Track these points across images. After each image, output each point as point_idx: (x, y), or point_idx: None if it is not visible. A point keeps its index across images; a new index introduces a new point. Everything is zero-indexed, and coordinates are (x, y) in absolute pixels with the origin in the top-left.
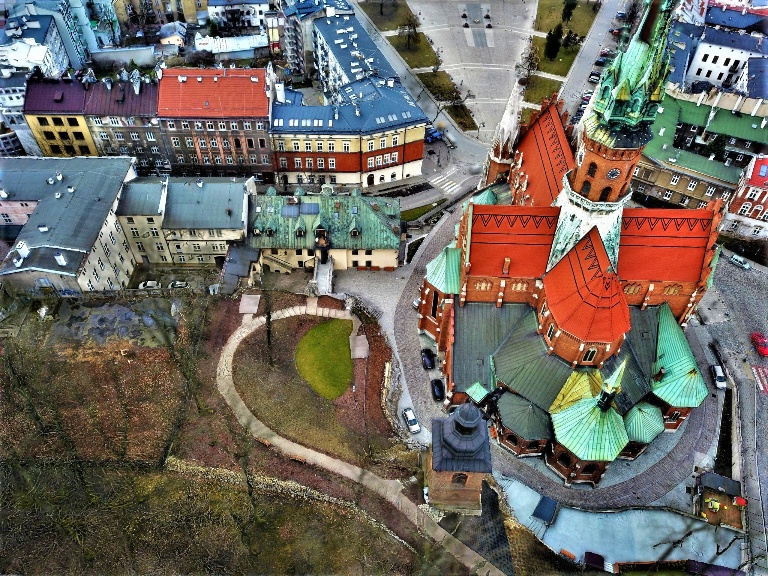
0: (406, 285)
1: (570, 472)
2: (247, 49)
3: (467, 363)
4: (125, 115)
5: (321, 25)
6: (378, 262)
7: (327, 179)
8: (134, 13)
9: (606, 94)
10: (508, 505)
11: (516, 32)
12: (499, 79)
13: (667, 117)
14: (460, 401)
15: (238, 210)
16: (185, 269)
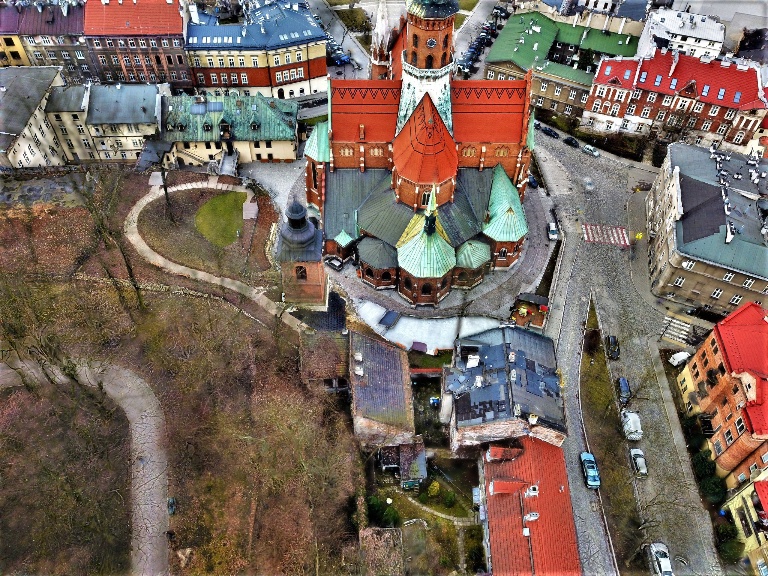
0: (302, 173)
1: (413, 294)
2: None
3: (336, 217)
4: (55, 34)
5: None
6: (278, 155)
7: (242, 94)
8: None
9: None
10: (358, 315)
11: None
12: None
13: (544, 36)
14: (333, 250)
15: (152, 107)
16: None
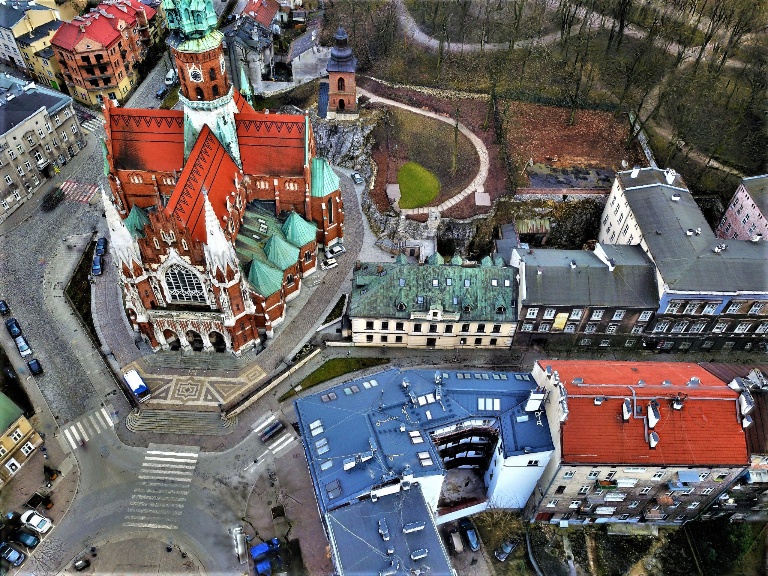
0: (349, 271)
1: None
2: None
3: None
4: None
5: None
6: None
7: None
8: None
9: None
10: None
11: None
12: None
13: None
14: None
15: None
16: None
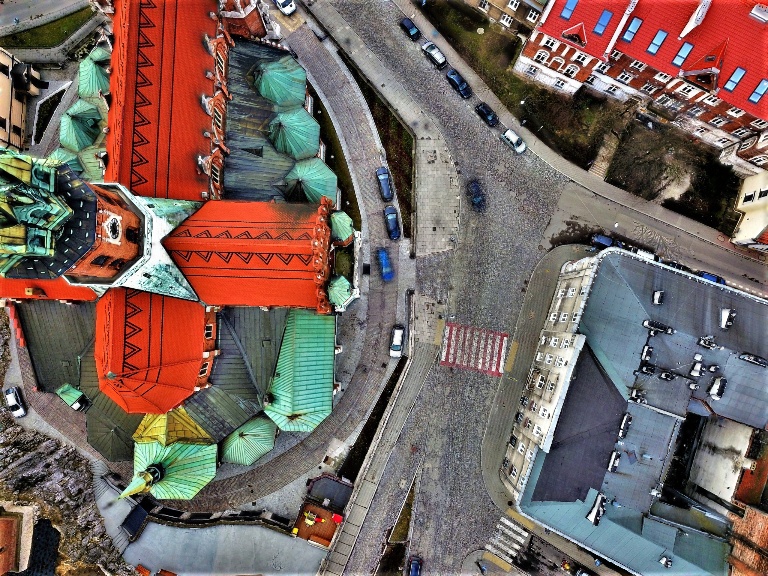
0: None
1: None
2: None
3: (51, 364)
4: None
5: None
6: None
7: None
8: None
9: None
10: (90, 523)
11: None
12: None
13: None
14: None
15: None
16: None
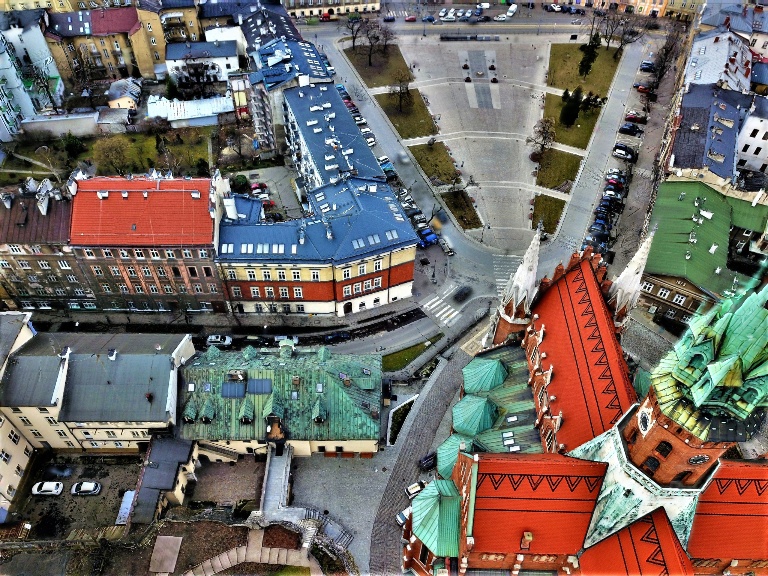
0: (388, 482)
1: None
2: (209, 115)
3: None
4: (28, 243)
5: (292, 98)
6: (352, 447)
7: (293, 308)
8: (80, 67)
9: (696, 363)
10: None
11: (526, 88)
12: (507, 153)
13: (717, 223)
14: None
15: (162, 394)
16: (98, 456)
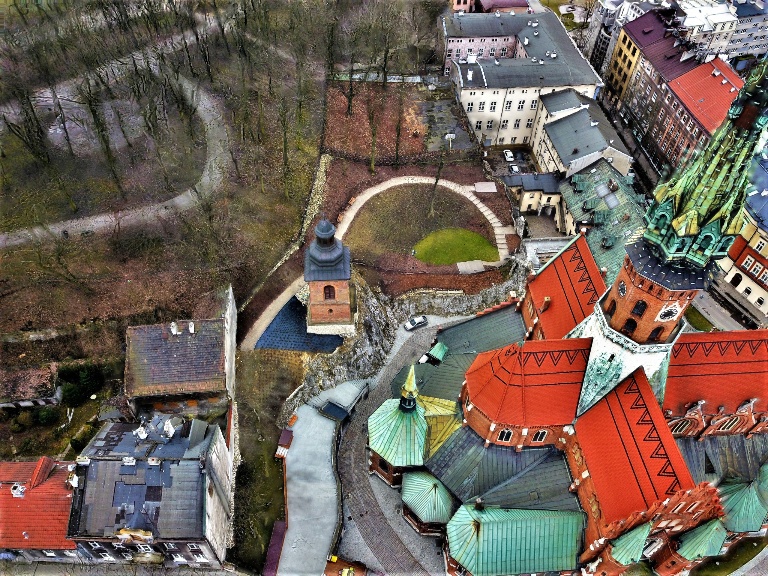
0: None
1: None
2: None
3: (464, 335)
4: (656, 68)
5: None
6: None
7: None
8: None
9: None
10: (333, 377)
11: None
12: None
13: None
14: None
15: (581, 155)
16: (536, 170)
